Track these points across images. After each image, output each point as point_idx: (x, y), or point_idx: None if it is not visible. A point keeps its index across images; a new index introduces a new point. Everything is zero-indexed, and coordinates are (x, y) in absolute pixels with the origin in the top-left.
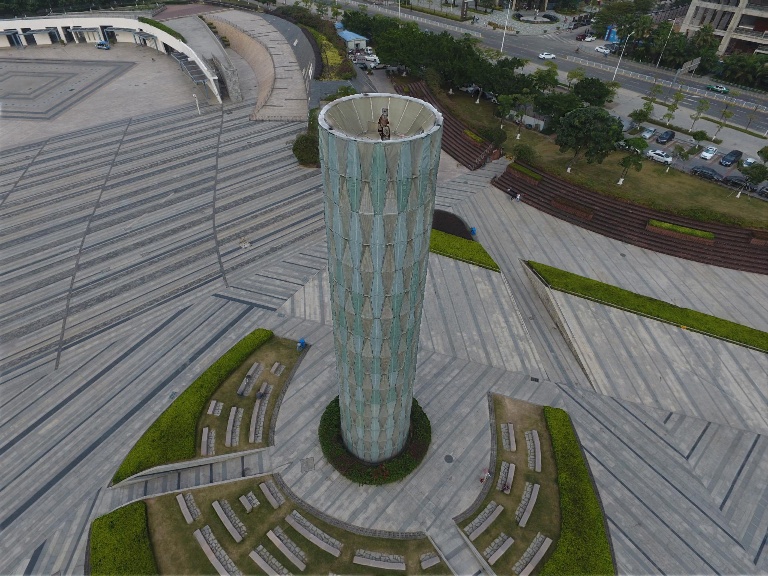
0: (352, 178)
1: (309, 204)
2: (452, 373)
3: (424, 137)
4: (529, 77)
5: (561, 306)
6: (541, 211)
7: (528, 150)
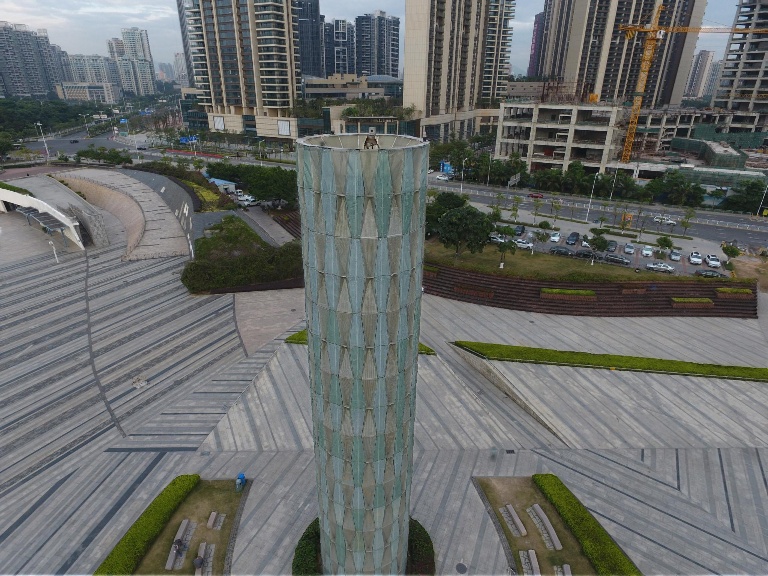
0: (352, 196)
1: (211, 329)
2: (426, 468)
3: (422, 146)
4: None
5: (504, 374)
6: (447, 298)
7: None
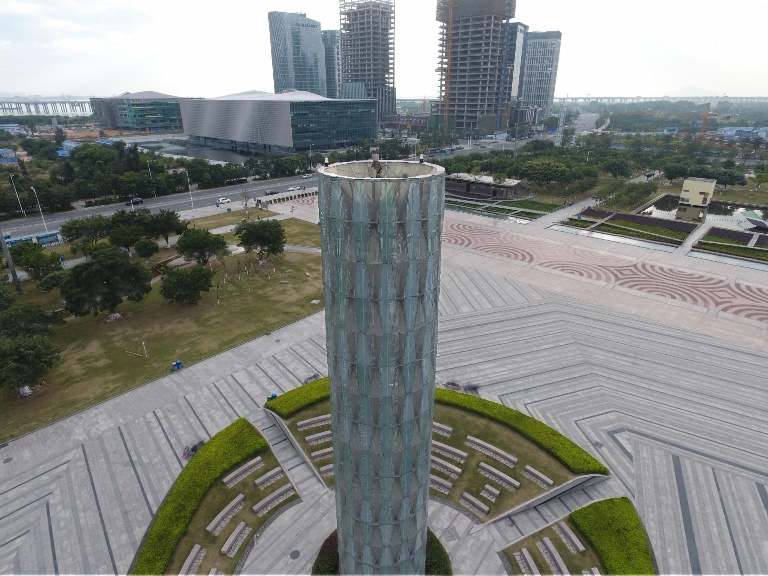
0: None
1: None
2: None
3: None
4: None
5: None
6: None
7: None
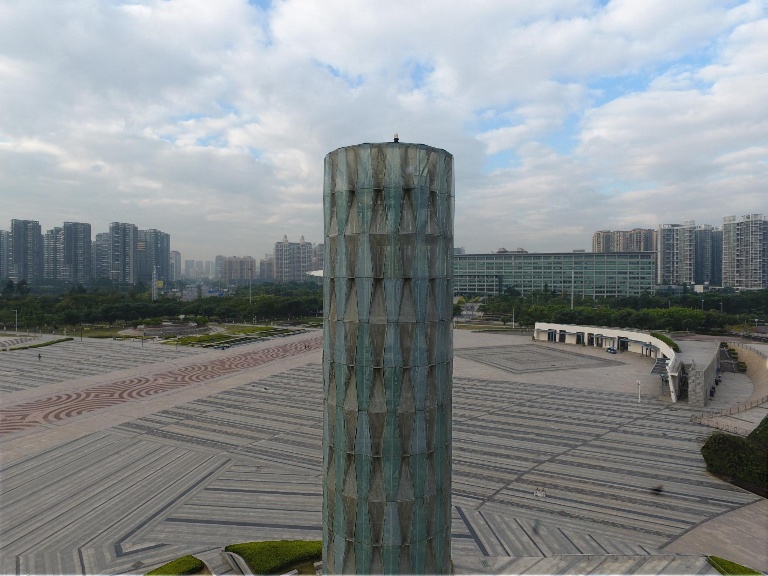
0: None
1: (669, 505)
2: None
3: (361, 145)
4: None
5: None
6: None
7: None
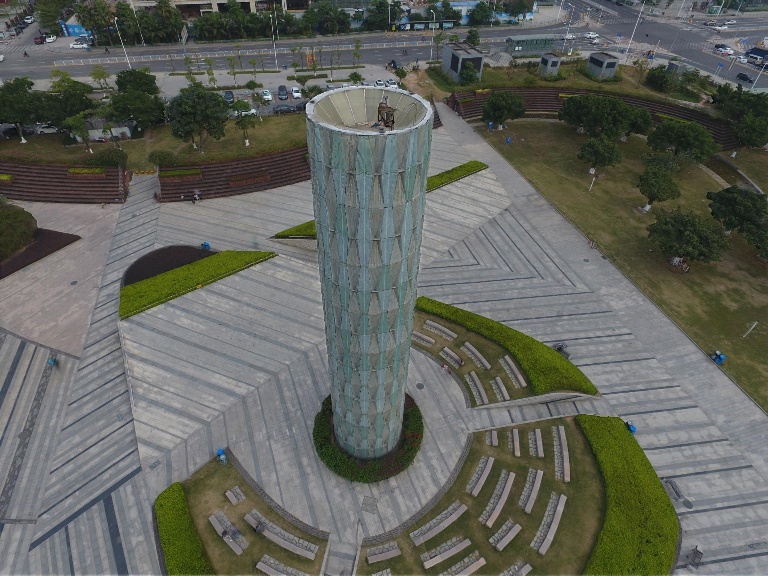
0: None
1: None
2: None
3: None
4: (70, 90)
5: None
6: (228, 197)
7: (165, 153)
